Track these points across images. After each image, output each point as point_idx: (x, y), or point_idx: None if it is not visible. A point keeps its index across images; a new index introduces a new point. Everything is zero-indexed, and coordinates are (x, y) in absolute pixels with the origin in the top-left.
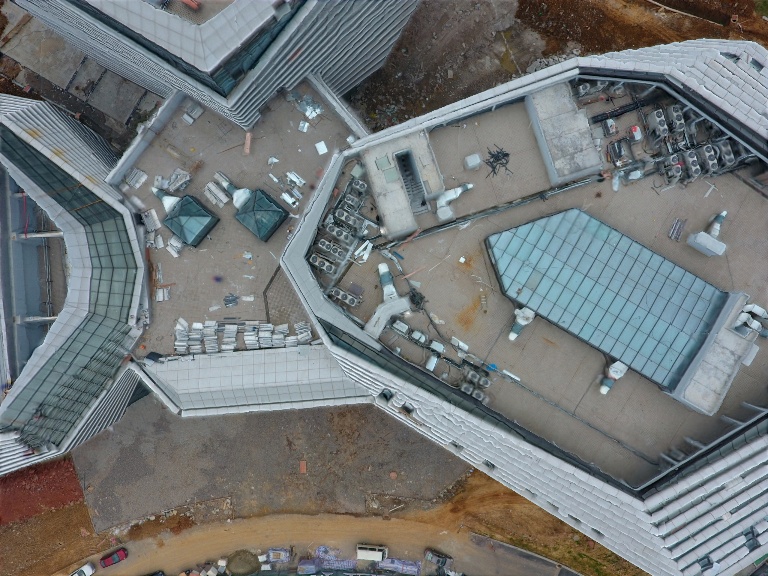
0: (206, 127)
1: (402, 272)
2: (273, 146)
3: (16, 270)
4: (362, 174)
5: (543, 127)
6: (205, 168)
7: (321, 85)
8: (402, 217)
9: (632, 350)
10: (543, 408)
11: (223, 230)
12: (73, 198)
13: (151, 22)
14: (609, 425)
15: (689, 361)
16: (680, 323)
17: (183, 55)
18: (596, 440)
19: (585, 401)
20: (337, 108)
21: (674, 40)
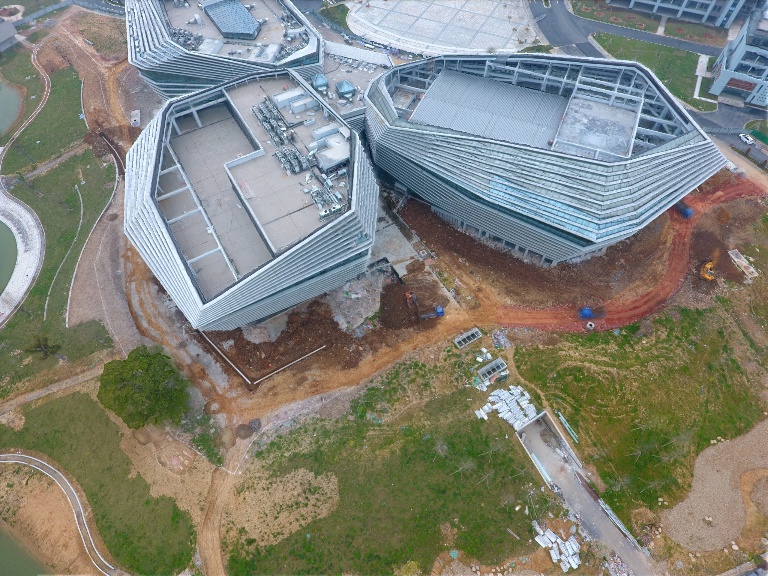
0: None
1: None
2: None
3: None
4: (275, 60)
5: None
6: None
7: None
8: (272, 46)
9: (239, 6)
10: (273, 9)
11: None
12: None
13: None
14: (260, 2)
15: (227, 0)
16: (222, 6)
17: None
18: (266, 1)
19: (261, 7)
20: None
21: (126, 135)
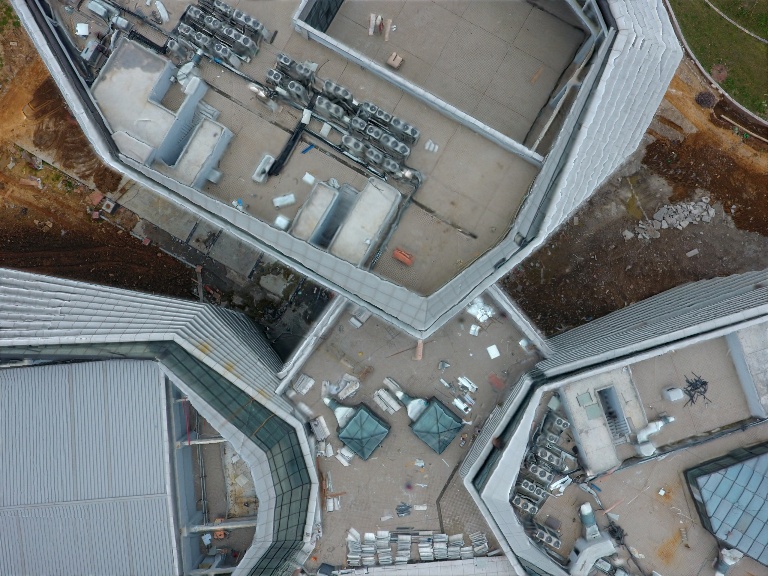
0: (374, 330)
1: (601, 506)
2: (443, 350)
3: (180, 479)
4: (560, 407)
5: (748, 362)
6: (375, 374)
7: (497, 293)
8: (605, 455)
9: None
10: None
11: (394, 437)
12: (250, 418)
13: (372, 289)
14: None
15: None
16: None
17: (400, 316)
18: None
19: None
20: (514, 317)
21: None
